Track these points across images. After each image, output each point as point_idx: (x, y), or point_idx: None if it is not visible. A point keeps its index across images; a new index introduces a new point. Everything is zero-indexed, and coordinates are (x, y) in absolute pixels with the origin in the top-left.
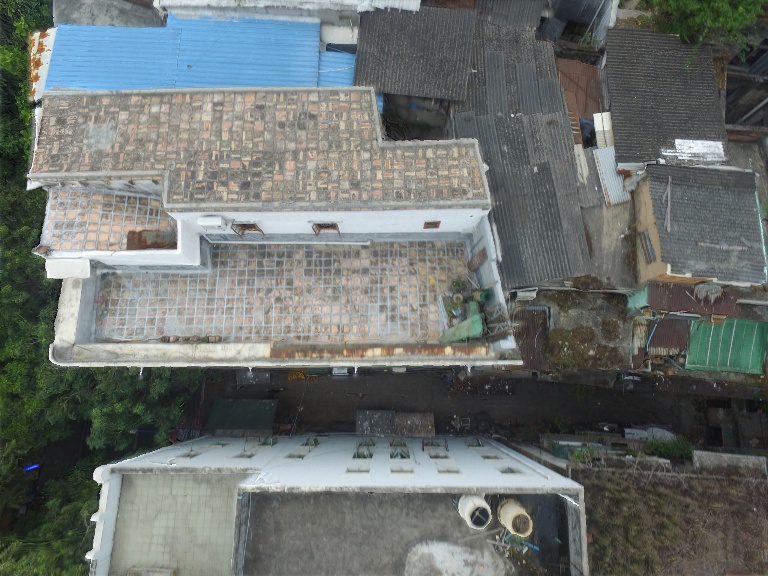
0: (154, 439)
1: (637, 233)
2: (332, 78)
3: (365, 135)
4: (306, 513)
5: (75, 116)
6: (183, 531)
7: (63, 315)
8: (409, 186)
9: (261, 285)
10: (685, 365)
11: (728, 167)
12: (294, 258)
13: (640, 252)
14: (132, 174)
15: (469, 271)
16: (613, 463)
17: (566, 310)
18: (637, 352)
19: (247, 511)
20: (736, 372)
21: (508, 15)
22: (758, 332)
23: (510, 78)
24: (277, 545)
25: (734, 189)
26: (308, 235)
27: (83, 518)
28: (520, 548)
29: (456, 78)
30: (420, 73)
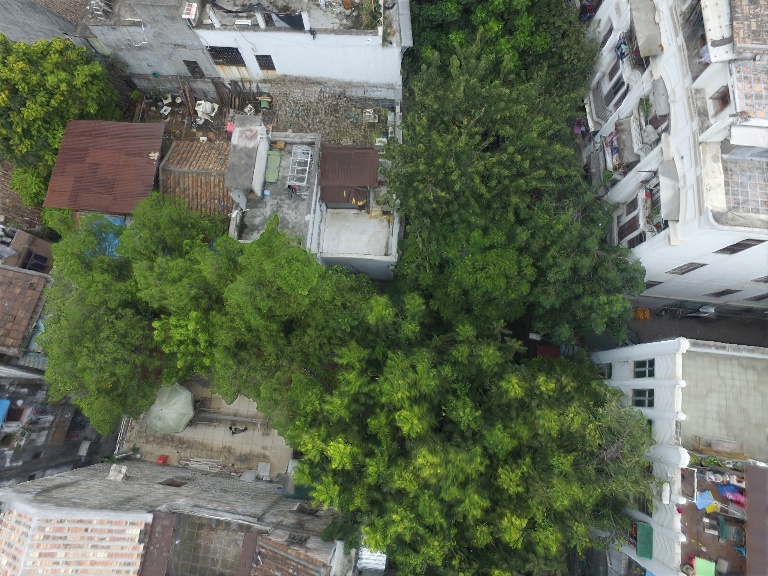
0: (535, 351)
1: None
2: None
3: None
4: None
5: None
6: (736, 410)
7: (709, 184)
8: None
9: None
10: None
11: None
12: None
13: None
14: None
15: None
16: None
17: None
18: None
19: None
20: None
21: None
22: None
23: None
24: None
25: None
26: None
27: None
28: None
29: None
30: None
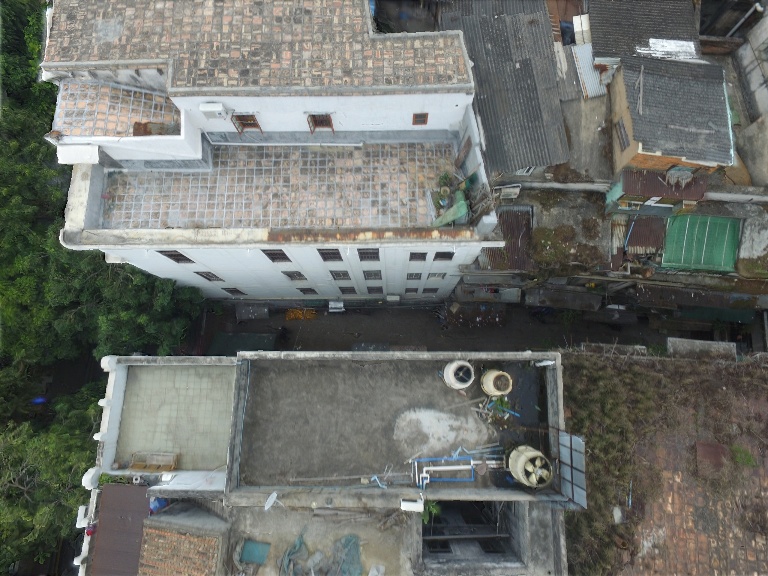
0: None
1: (613, 124)
2: None
3: (357, 28)
4: (301, 383)
5: (84, 12)
6: (185, 421)
7: (73, 204)
8: (398, 73)
9: (259, 183)
10: (661, 263)
11: (698, 60)
12: (291, 158)
13: (616, 142)
14: (138, 62)
15: (456, 168)
16: (592, 349)
17: (548, 208)
18: (616, 252)
19: (246, 381)
20: (710, 270)
21: None
22: (730, 230)
23: None
24: (274, 411)
25: (703, 80)
26: (304, 134)
27: (89, 423)
28: (502, 415)
29: None
30: None
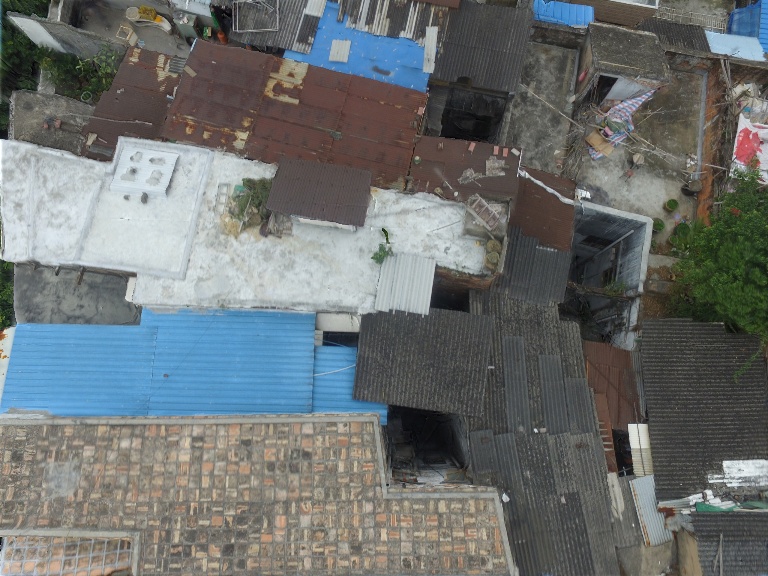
0: None
1: None
2: (329, 382)
3: (367, 479)
4: None
5: (33, 450)
6: None
7: None
8: (419, 551)
9: None
10: None
11: None
12: None
13: None
14: (97, 536)
15: None
16: None
17: None
18: None
19: None
20: None
21: (528, 289)
22: None
23: (532, 376)
24: None
25: None
26: None
27: None
28: None
29: (471, 390)
30: (430, 383)
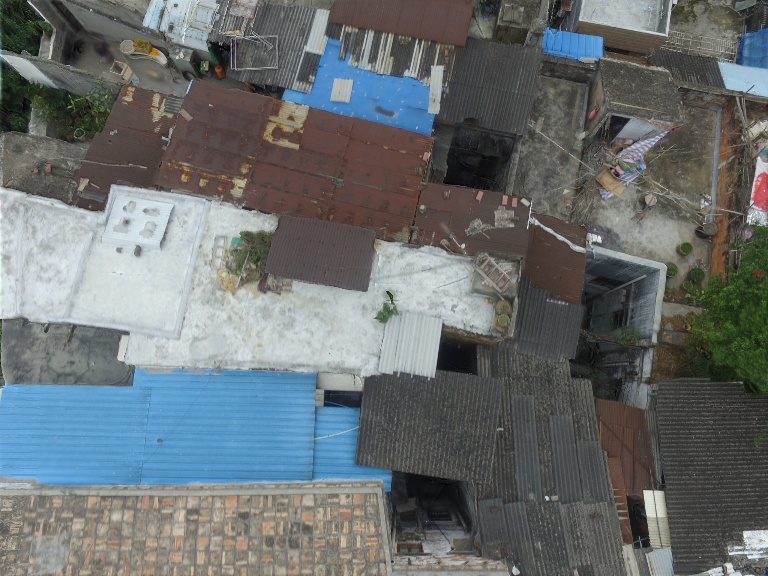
0: None
1: None
2: (331, 445)
3: (371, 555)
4: None
5: (20, 523)
6: None
7: None
8: None
9: None
10: None
11: None
12: None
13: None
14: None
15: None
16: None
17: None
18: None
19: None
20: None
21: (538, 344)
22: None
23: (543, 438)
24: None
25: None
26: None
27: None
28: None
29: (479, 456)
30: (436, 448)
